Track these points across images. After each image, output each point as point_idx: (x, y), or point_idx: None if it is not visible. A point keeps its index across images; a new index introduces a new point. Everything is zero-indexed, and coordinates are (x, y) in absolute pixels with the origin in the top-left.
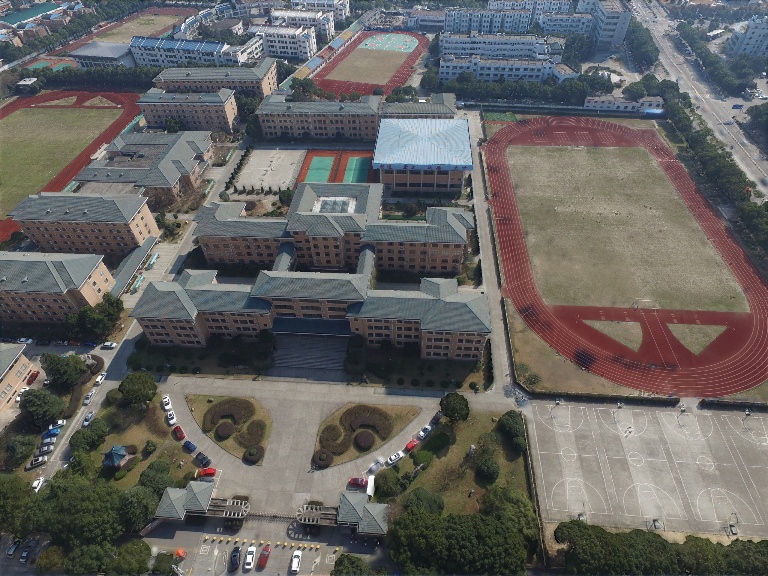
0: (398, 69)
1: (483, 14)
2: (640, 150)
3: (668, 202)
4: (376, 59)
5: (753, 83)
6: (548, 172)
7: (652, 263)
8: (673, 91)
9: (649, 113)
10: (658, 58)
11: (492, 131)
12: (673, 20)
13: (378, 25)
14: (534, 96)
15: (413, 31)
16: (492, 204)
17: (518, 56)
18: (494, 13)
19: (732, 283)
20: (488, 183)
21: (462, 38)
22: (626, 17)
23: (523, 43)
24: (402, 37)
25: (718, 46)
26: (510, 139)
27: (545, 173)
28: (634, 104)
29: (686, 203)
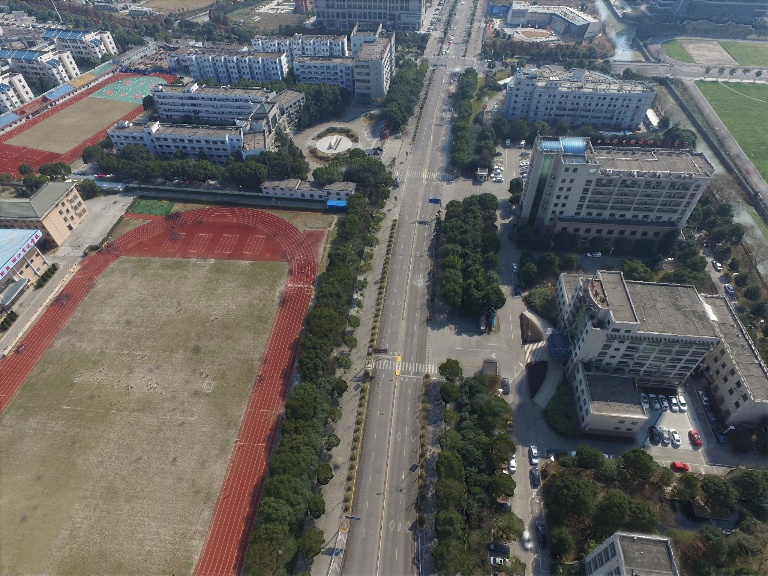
0: (102, 129)
1: (227, 58)
2: (279, 267)
3: (238, 365)
4: (91, 114)
5: (488, 160)
6: (128, 305)
7: (115, 494)
8: (368, 176)
9: (331, 206)
10: (419, 116)
11: (122, 231)
12: (481, 60)
13: (143, 64)
14: (199, 180)
15: (173, 73)
16: (1, 366)
17: (246, 114)
18: (239, 57)
19: (195, 542)
20: (32, 325)
21: (174, 93)
22: (377, 66)
23: (246, 99)
24: (153, 82)
25: (504, 98)
26: (132, 245)
27: (123, 307)
28: (319, 192)
29: (261, 368)
